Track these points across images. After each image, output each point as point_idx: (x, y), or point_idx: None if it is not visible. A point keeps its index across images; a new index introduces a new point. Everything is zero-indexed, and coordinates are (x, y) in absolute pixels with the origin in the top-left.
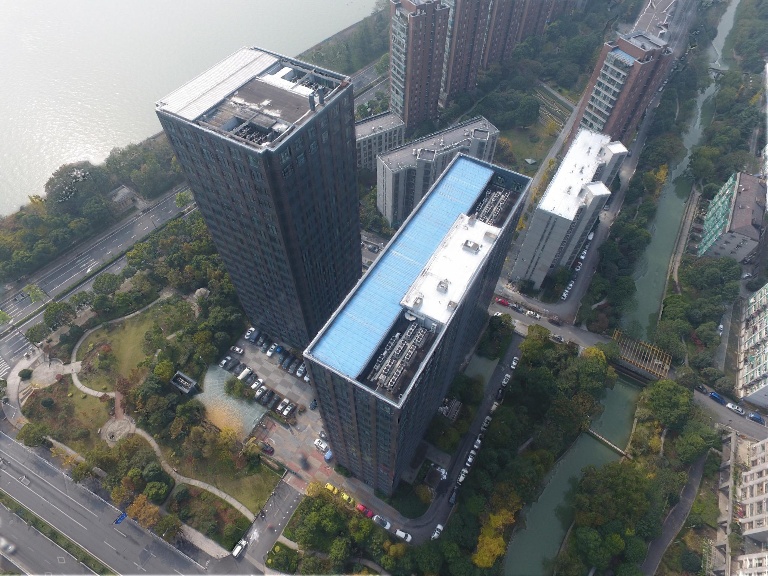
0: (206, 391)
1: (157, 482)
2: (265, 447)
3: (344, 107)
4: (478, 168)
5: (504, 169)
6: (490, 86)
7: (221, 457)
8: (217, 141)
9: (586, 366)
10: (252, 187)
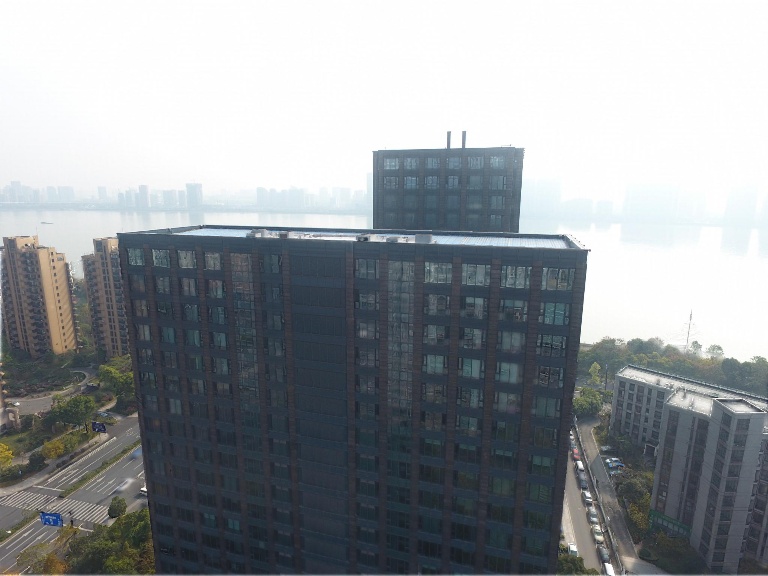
0: None
1: None
2: None
3: (494, 167)
4: (557, 244)
5: (576, 242)
6: None
7: None
8: None
9: None
10: None
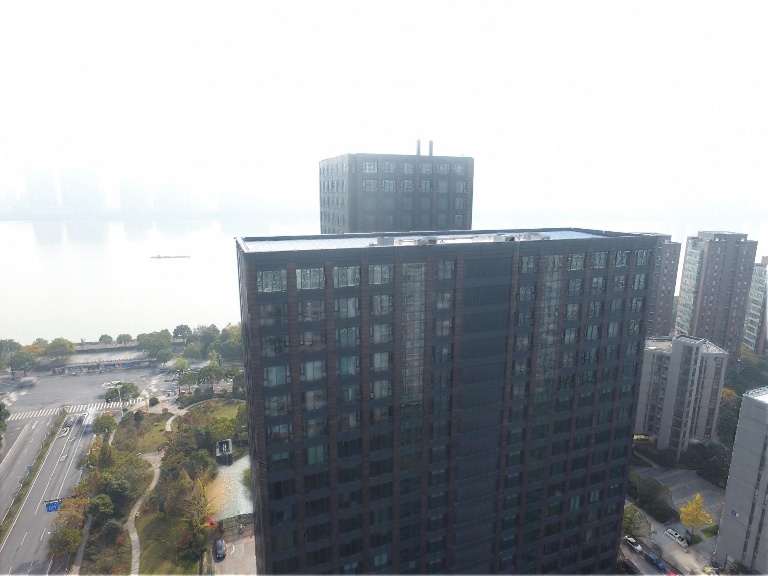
0: (232, 466)
1: (110, 498)
2: (219, 547)
3: (457, 174)
4: None
5: None
6: (764, 370)
7: (177, 527)
8: (334, 164)
9: None
10: (342, 203)
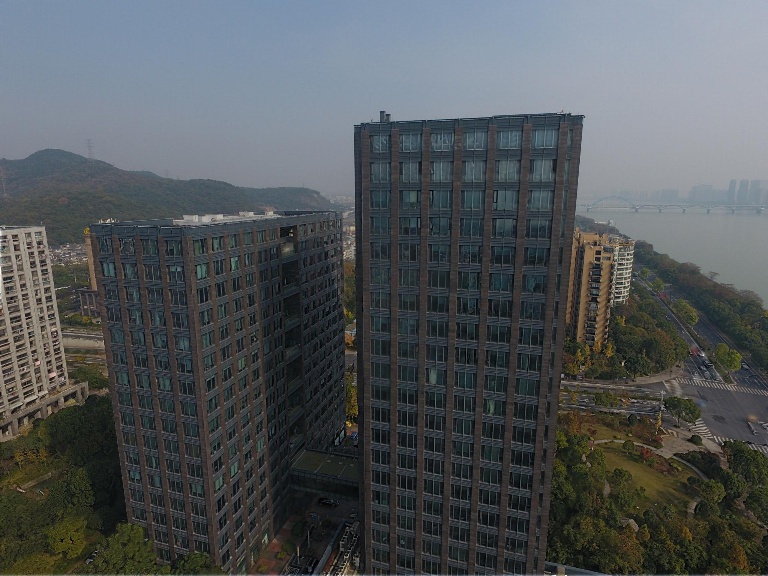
0: None
1: None
2: None
3: None
4: None
5: None
6: None
7: None
8: None
9: (1, 508)
10: None
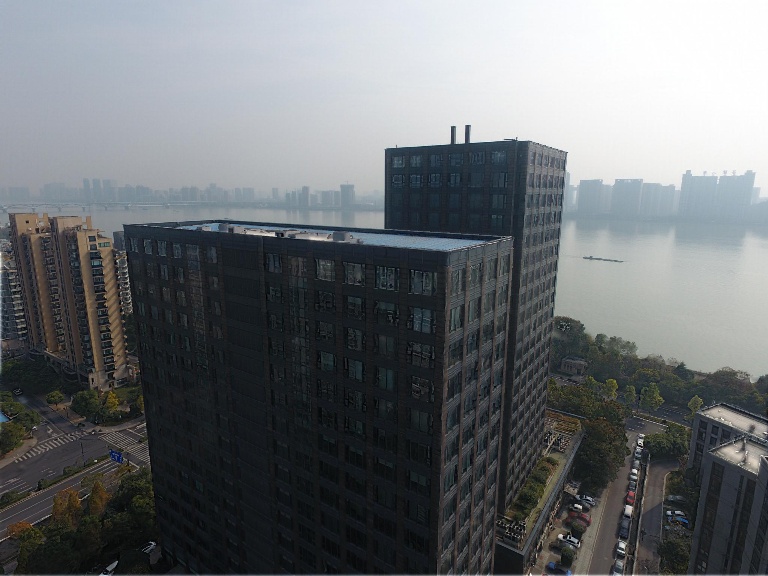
0: None
1: None
2: None
3: (495, 163)
4: None
5: (474, 244)
6: None
7: None
8: None
9: None
10: None
